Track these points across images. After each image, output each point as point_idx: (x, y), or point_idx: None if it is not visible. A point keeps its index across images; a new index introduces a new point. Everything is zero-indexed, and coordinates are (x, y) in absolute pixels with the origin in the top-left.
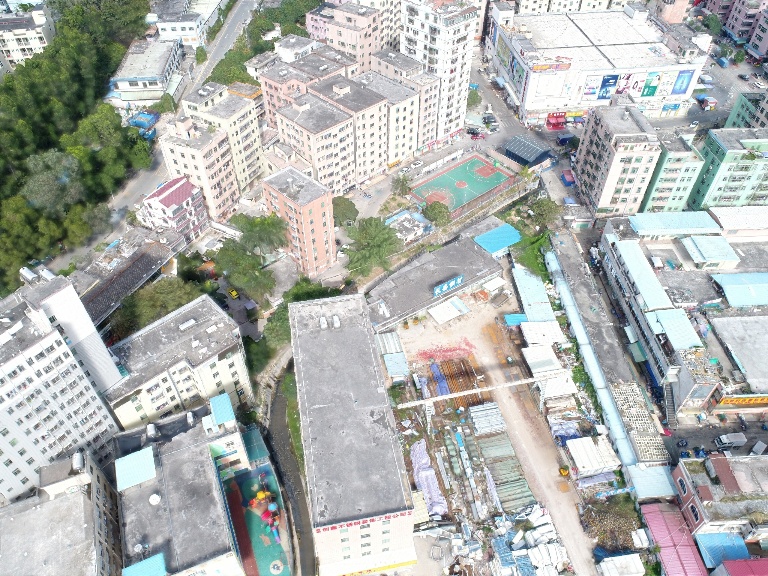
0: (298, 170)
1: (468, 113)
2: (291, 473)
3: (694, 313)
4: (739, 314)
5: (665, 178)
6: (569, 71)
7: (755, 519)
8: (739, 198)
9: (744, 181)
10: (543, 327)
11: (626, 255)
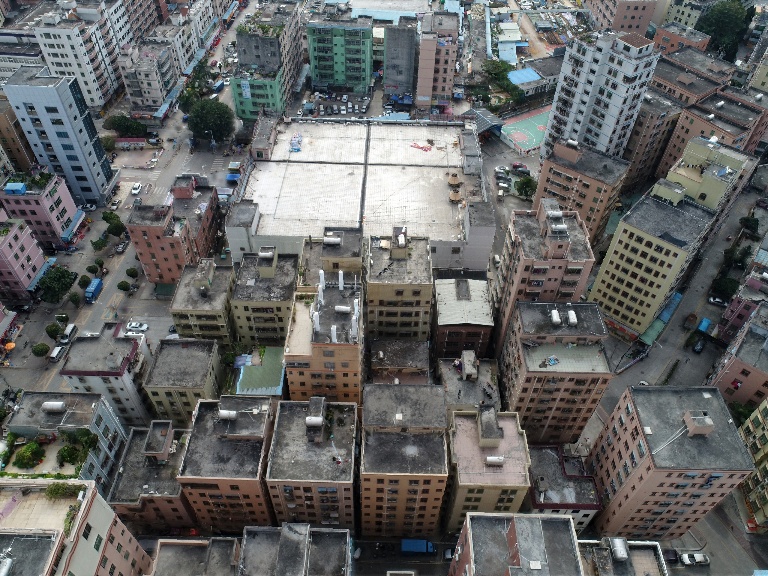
0: (688, 39)
1: None
2: None
3: None
4: None
5: None
6: (430, 121)
7: None
8: None
9: None
10: None
11: None
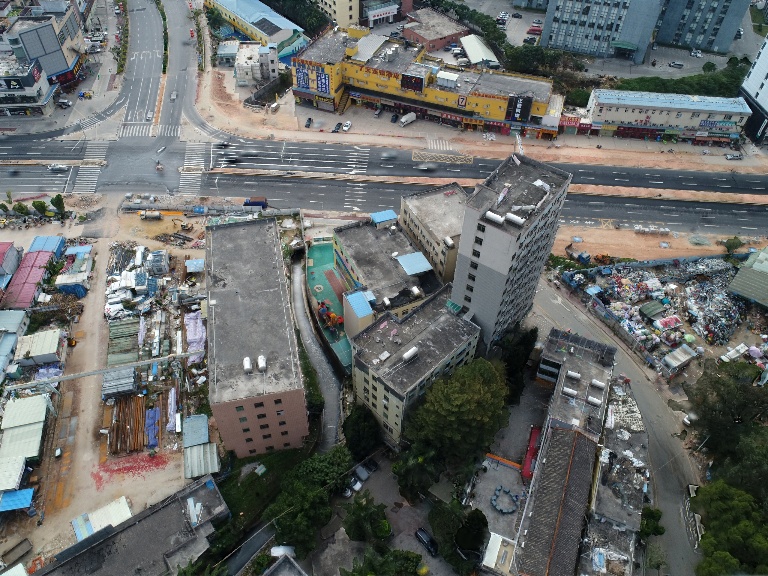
0: None
1: None
2: (315, 355)
3: None
4: None
5: None
6: None
7: None
8: None
9: None
10: None
11: None
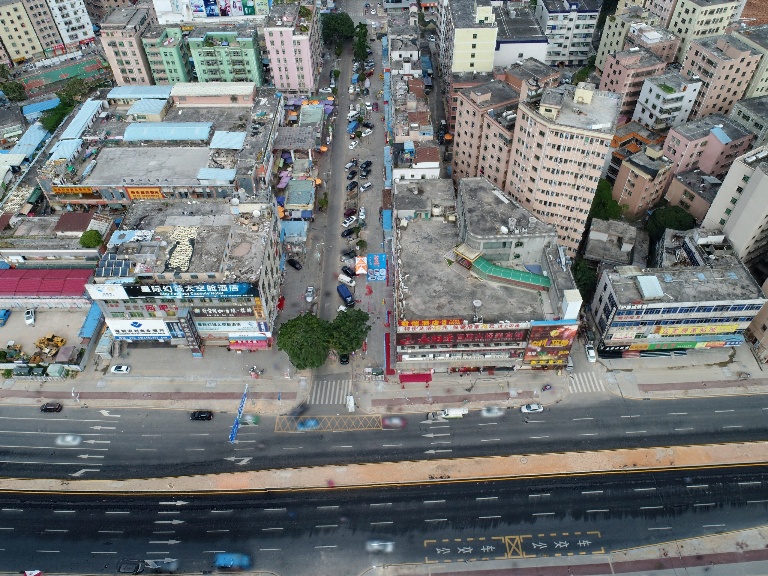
0: None
1: None
2: None
3: (99, 145)
4: (129, 146)
5: (153, 61)
6: None
7: (1, 246)
8: (226, 81)
9: (219, 66)
10: (11, 157)
11: (82, 109)
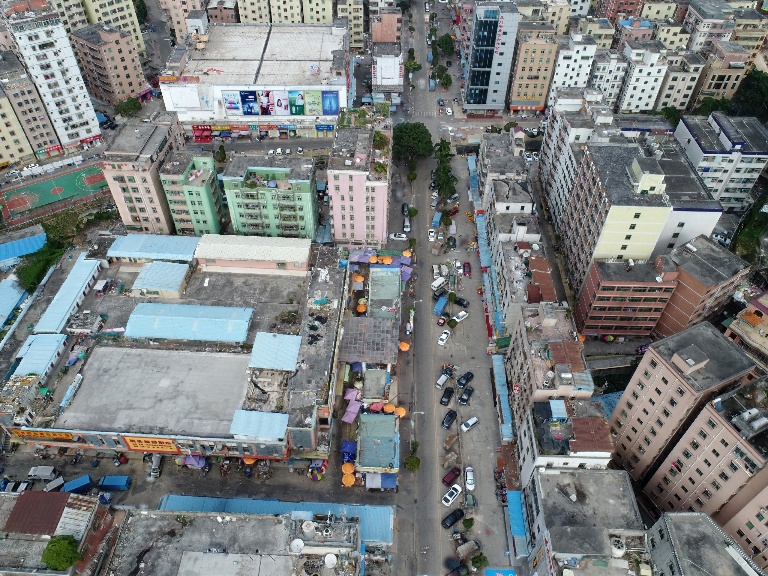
0: None
1: (131, 120)
2: None
3: (89, 340)
4: (133, 345)
5: (173, 200)
6: (199, 84)
7: None
8: (269, 226)
9: (262, 209)
10: None
11: (71, 275)
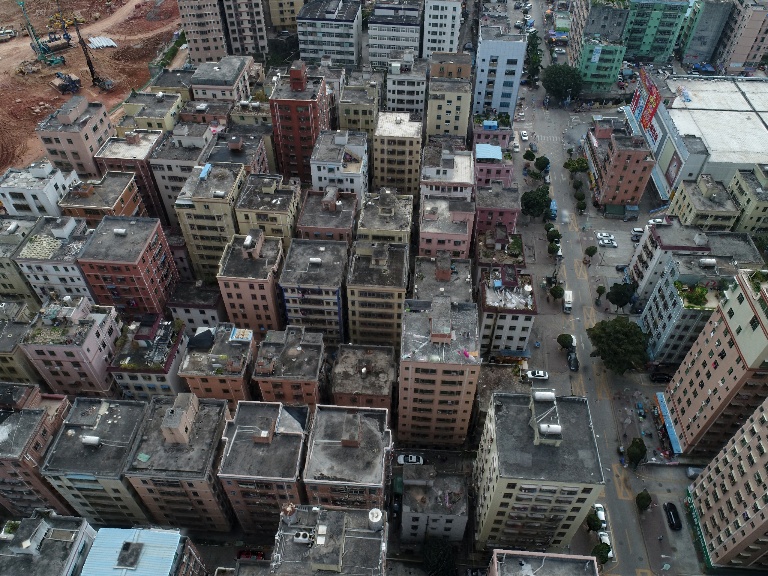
0: None
1: None
2: None
3: None
4: None
5: None
6: None
7: None
8: None
9: None
10: None
11: None
